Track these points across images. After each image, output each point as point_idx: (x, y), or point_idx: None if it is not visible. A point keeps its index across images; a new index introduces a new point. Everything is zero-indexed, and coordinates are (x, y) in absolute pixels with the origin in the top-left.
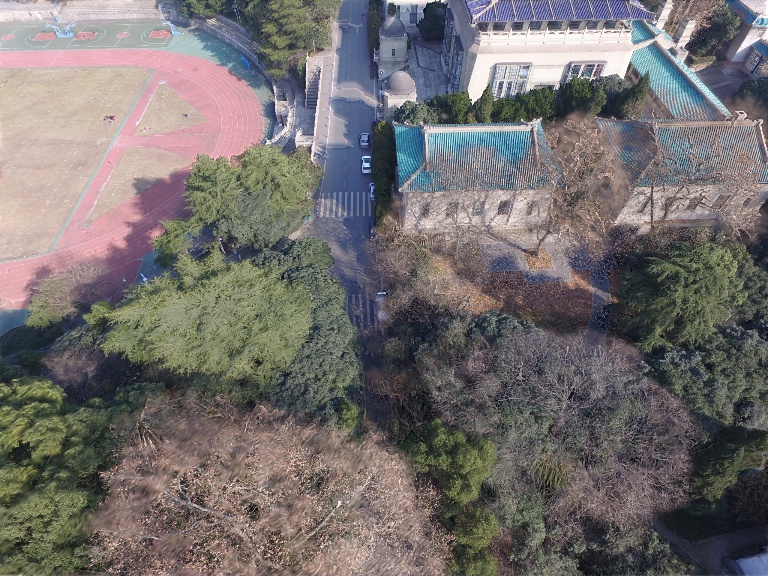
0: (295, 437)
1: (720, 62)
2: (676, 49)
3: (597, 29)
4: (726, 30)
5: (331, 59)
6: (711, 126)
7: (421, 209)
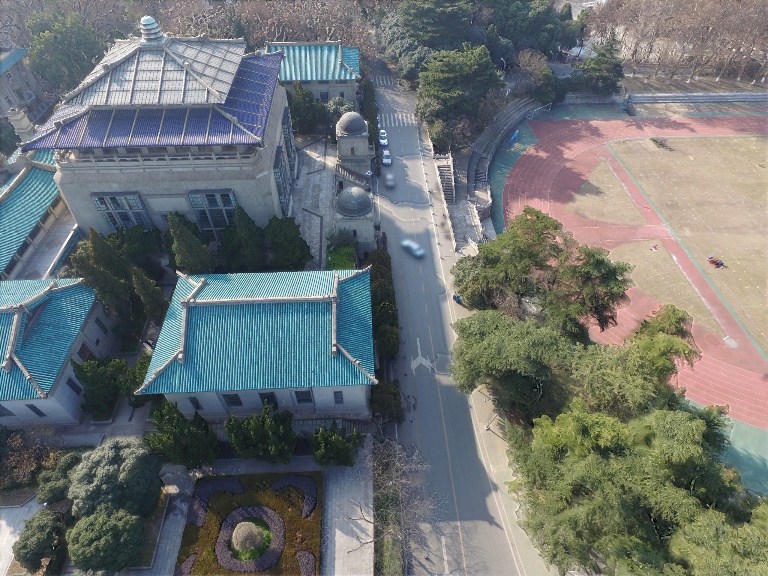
0: None
1: None
2: None
3: None
4: None
5: (448, 269)
6: None
7: None
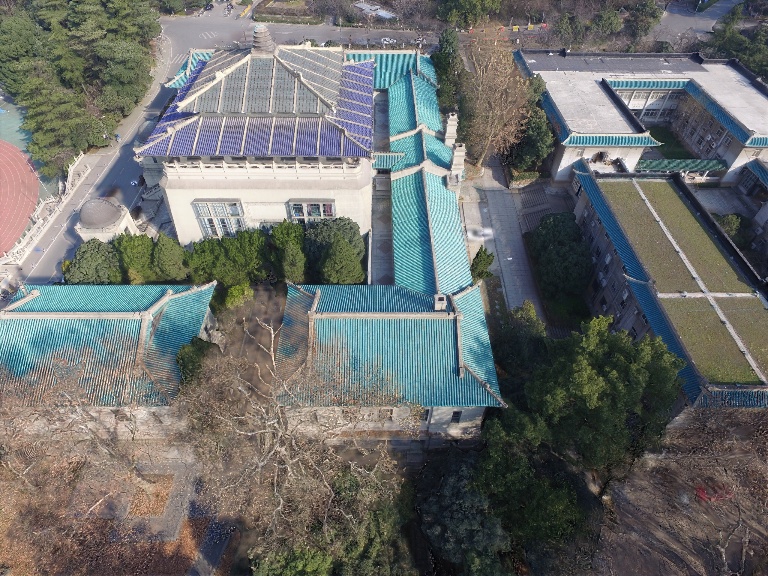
0: None
1: (545, 179)
2: (450, 178)
3: (319, 161)
4: (538, 147)
5: (108, 158)
6: (393, 318)
7: None
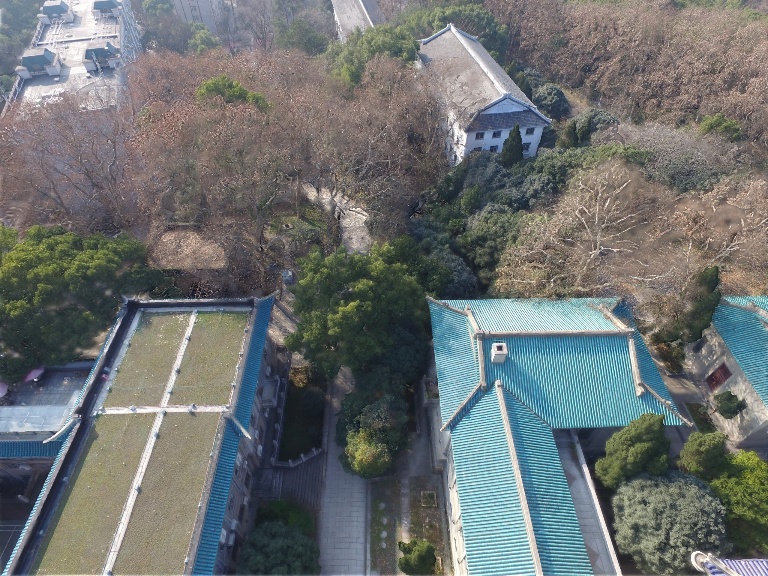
0: None
1: None
2: None
3: None
4: None
5: None
6: None
7: None
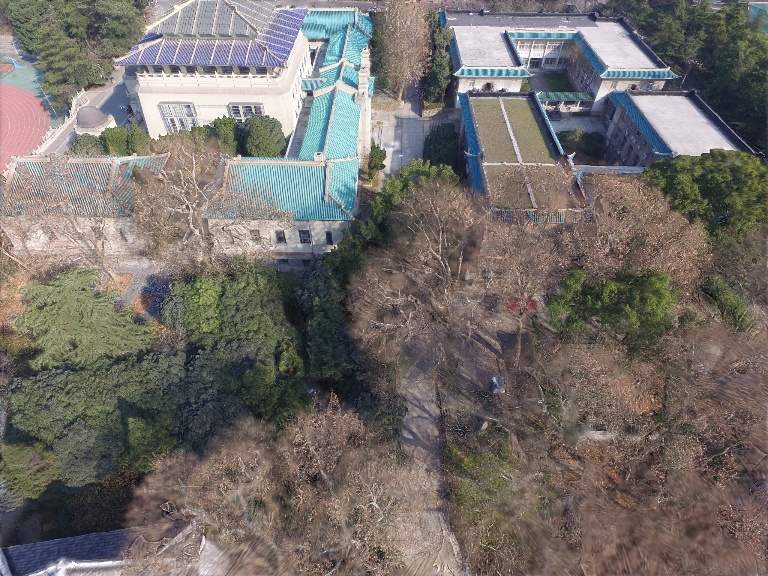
0: None
1: (450, 108)
2: (357, 95)
3: None
4: (438, 79)
5: (104, 94)
6: (283, 165)
7: (18, 231)
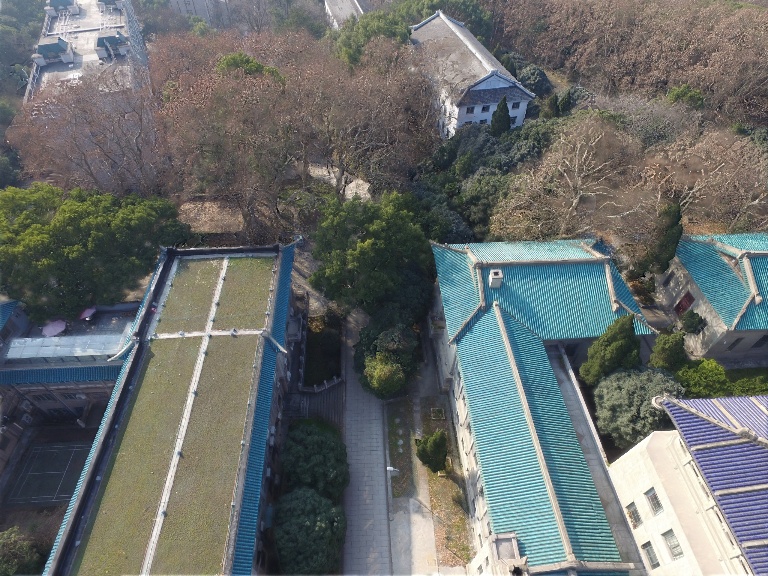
0: (767, 61)
1: None
2: None
3: None
4: None
5: None
6: None
7: None
